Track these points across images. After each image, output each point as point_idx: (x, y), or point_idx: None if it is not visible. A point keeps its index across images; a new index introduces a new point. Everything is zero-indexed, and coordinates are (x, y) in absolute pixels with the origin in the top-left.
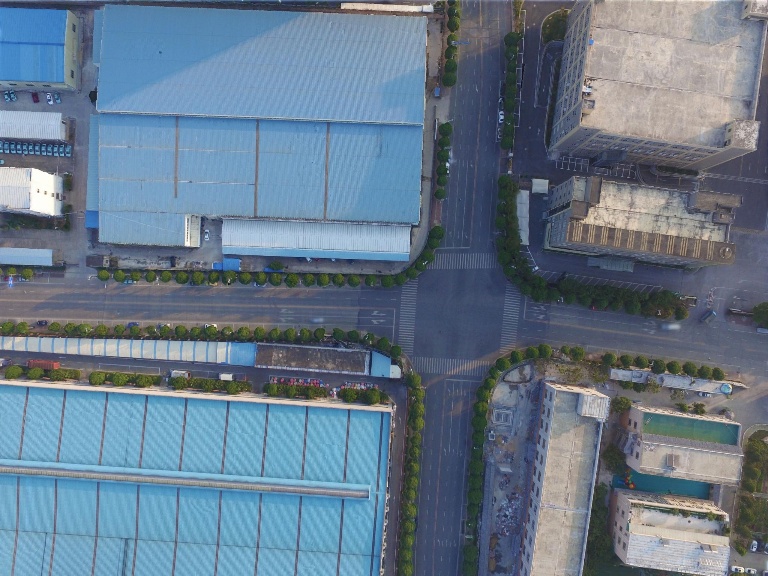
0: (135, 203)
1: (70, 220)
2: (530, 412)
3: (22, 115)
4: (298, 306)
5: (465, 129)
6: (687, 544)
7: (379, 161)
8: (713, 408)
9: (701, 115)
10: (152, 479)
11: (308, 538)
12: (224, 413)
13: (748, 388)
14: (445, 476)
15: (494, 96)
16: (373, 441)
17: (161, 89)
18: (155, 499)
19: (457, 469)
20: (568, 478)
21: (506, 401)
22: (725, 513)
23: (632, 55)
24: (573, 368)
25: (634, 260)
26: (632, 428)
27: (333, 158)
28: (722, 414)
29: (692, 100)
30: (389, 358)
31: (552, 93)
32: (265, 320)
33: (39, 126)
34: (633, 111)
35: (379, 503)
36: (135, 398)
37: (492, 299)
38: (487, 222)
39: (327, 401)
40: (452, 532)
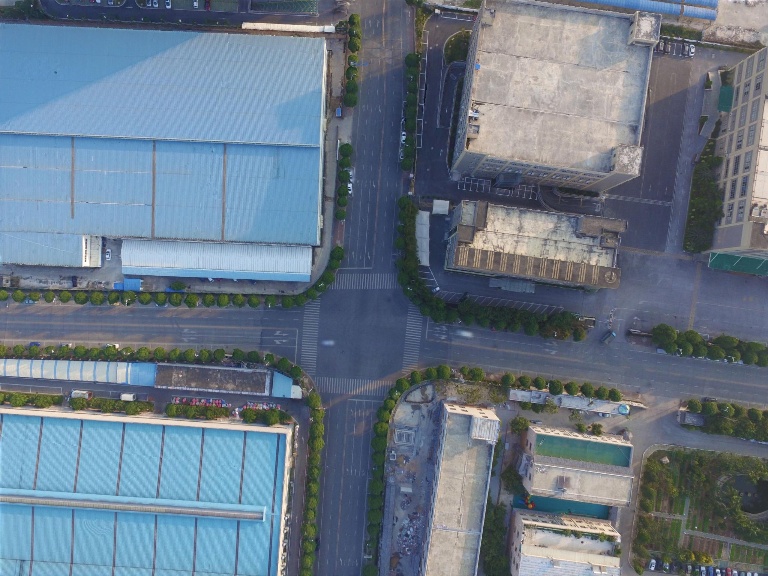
0: (32, 223)
1: None
2: (432, 432)
3: None
4: (200, 326)
5: (368, 149)
6: (578, 565)
7: (276, 182)
8: (613, 428)
9: (588, 140)
10: (46, 501)
11: (204, 559)
12: (120, 434)
13: (647, 408)
14: (347, 496)
15: (397, 117)
16: (269, 462)
17: (56, 109)
18: (50, 521)
19: (359, 489)
20: (461, 500)
21: (408, 421)
22: (617, 534)
23: (519, 80)
24: (474, 388)
25: (532, 282)
26: (528, 449)
27: (230, 179)
28: (621, 434)
29: (579, 125)
30: (290, 378)
31: (454, 114)
32: (167, 340)
33: None
34: (520, 136)
35: (274, 524)
36: (30, 419)
37: (394, 319)
38: (390, 242)
39: (227, 422)
40: (354, 551)
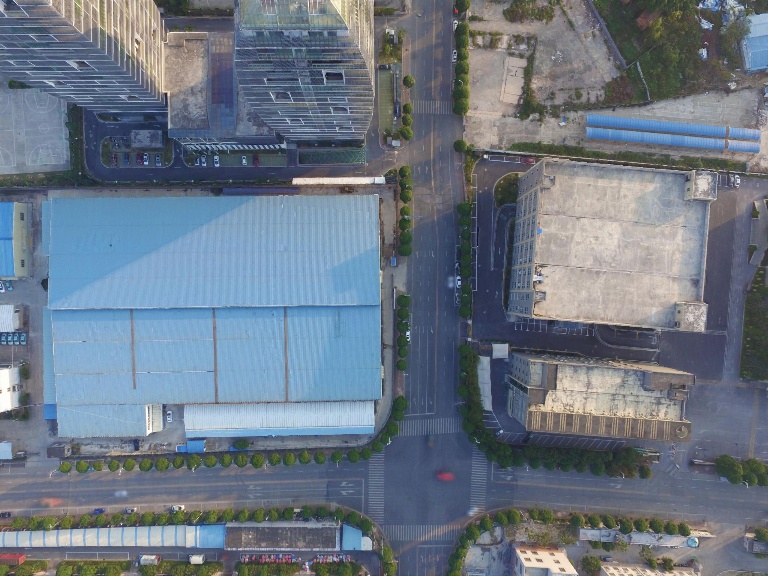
0: (93, 397)
1: (28, 409)
2: (503, 573)
3: None
4: (266, 482)
5: (423, 295)
6: None
7: (338, 341)
8: (682, 558)
9: (651, 296)
10: None
11: None
12: None
13: (714, 537)
14: None
15: (450, 261)
16: None
17: (113, 283)
18: None
19: None
20: None
21: (479, 563)
22: None
23: (580, 240)
24: (543, 528)
25: None
26: None
27: (292, 341)
28: (691, 564)
29: (641, 281)
30: (360, 530)
31: (507, 257)
32: (233, 498)
33: None
34: (584, 296)
35: None
36: None
37: (459, 463)
38: (450, 387)
39: None
40: None
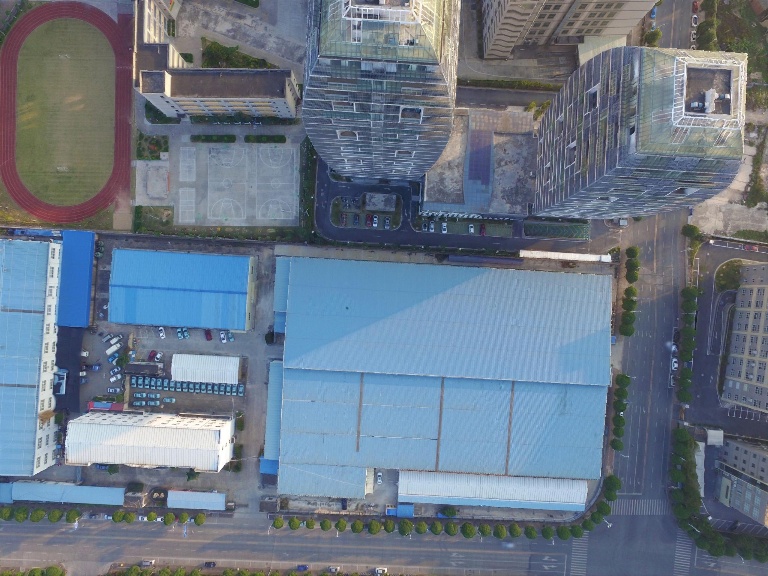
0: (316, 456)
1: (241, 461)
2: None
3: (200, 360)
4: (469, 550)
5: (638, 375)
6: None
7: (562, 419)
8: None
9: None
10: None
11: None
12: None
13: None
14: None
15: (667, 343)
16: None
17: (348, 346)
18: None
19: None
20: None
21: None
22: None
23: None
24: None
25: None
26: None
27: (517, 415)
28: None
29: None
30: None
31: (726, 343)
32: (436, 564)
33: (217, 372)
34: None
35: None
36: None
37: (663, 546)
38: (659, 468)
39: None
40: None
